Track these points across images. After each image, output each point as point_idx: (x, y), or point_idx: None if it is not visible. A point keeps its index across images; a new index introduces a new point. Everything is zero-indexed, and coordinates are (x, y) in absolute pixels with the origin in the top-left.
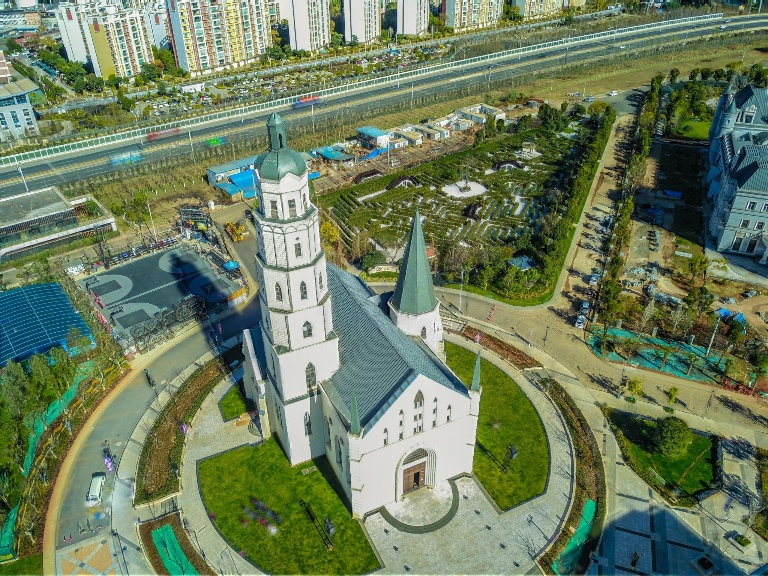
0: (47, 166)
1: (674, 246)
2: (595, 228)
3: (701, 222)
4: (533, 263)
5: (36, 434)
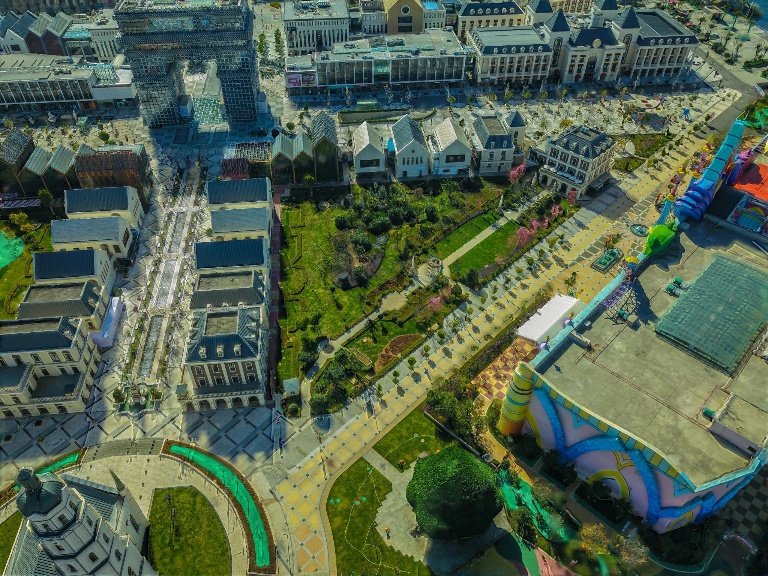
0: None
1: None
2: None
3: None
4: None
5: None
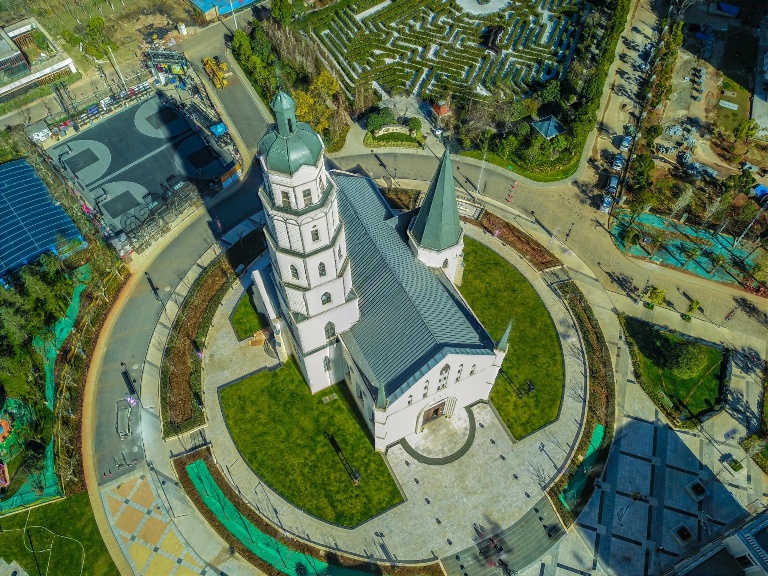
0: None
1: (719, 92)
2: (633, 63)
3: (755, 54)
4: (561, 128)
5: (50, 360)
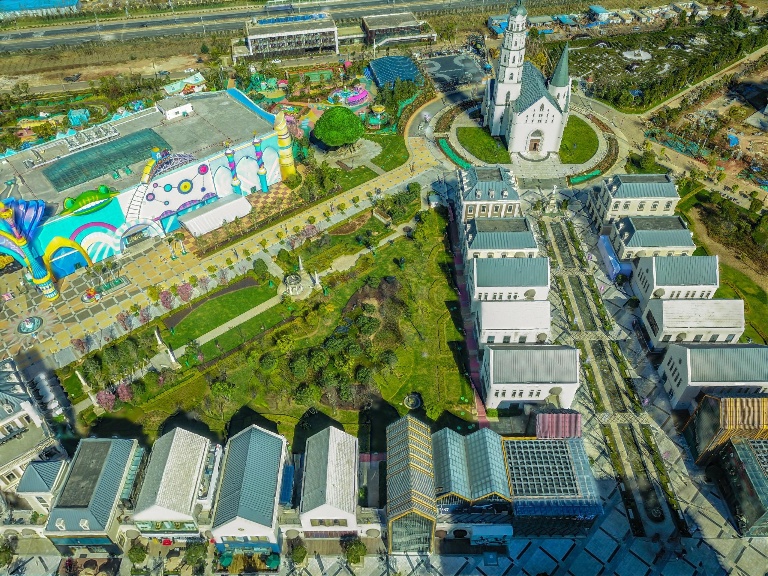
0: (401, 1)
1: (740, 106)
2: None
3: None
4: (641, 94)
5: (402, 107)
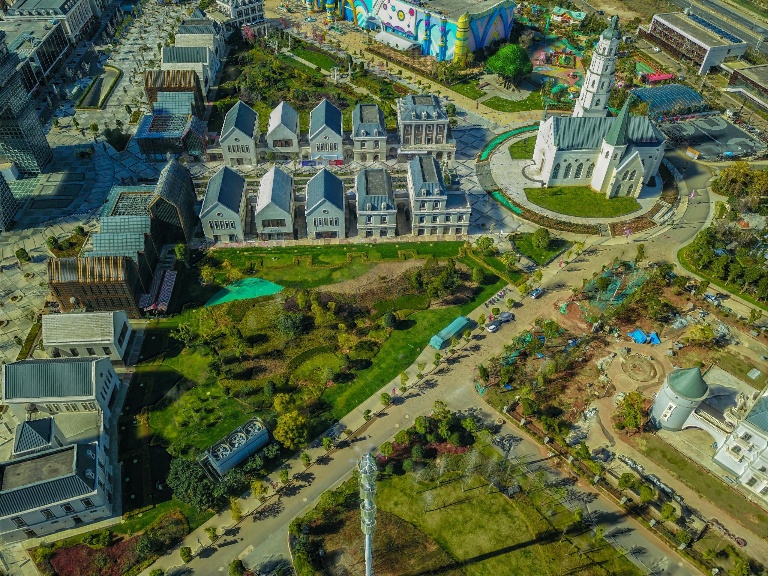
0: None
1: None
2: None
3: None
4: None
5: None
